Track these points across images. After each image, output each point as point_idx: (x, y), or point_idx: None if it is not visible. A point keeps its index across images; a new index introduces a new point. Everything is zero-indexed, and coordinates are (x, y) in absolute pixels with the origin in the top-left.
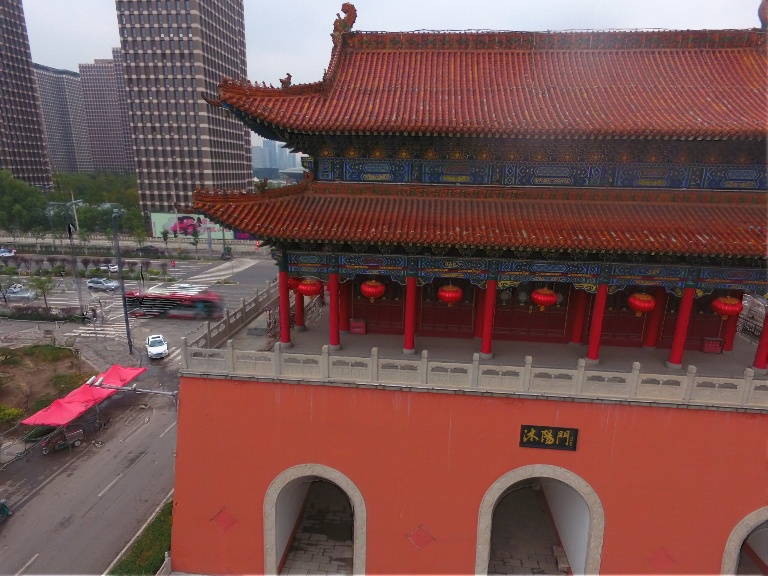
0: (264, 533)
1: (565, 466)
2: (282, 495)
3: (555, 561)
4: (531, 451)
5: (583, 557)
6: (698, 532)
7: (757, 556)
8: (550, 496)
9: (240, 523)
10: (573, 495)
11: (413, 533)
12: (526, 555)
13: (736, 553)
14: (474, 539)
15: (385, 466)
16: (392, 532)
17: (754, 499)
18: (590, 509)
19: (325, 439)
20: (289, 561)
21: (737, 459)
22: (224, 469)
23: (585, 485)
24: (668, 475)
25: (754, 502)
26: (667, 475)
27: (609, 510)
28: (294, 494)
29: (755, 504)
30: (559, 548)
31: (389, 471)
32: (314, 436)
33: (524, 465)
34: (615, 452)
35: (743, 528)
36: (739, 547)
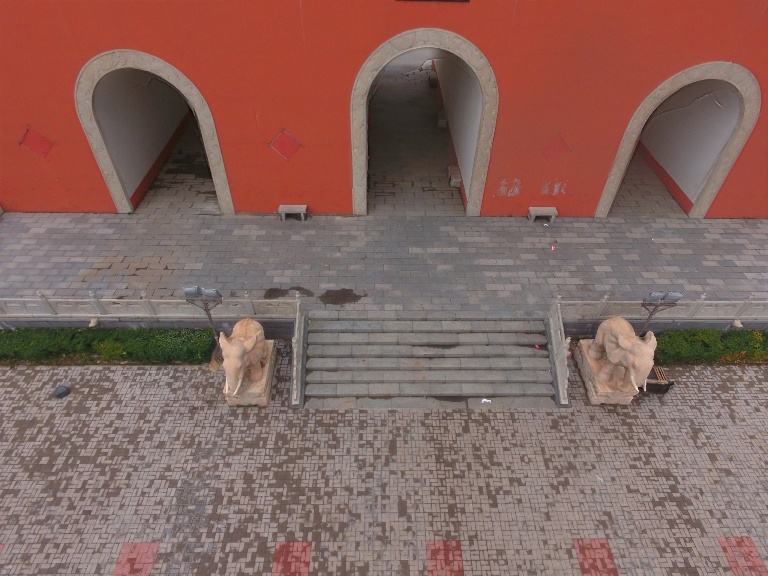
0: (95, 155)
1: (455, 29)
2: (99, 103)
3: (448, 179)
4: (411, 6)
5: (472, 156)
6: (602, 111)
7: (657, 163)
8: (453, 123)
9: (59, 145)
10: (471, 95)
11: (276, 140)
12: (419, 178)
13: (637, 133)
14: (348, 142)
15: (221, 46)
16: (250, 141)
17: (675, 61)
18: (483, 90)
19: (126, 7)
20: (149, 197)
21: (671, 1)
22: (3, 68)
23: (479, 56)
24: (581, 33)
25: (674, 65)
26: (580, 33)
27: (505, 90)
28: (140, 126)
29: (674, 68)
30: (454, 167)
31: (228, 54)
32: (108, 2)
33: (403, 31)
34: (520, 0)
35: (652, 101)
36: (642, 126)
